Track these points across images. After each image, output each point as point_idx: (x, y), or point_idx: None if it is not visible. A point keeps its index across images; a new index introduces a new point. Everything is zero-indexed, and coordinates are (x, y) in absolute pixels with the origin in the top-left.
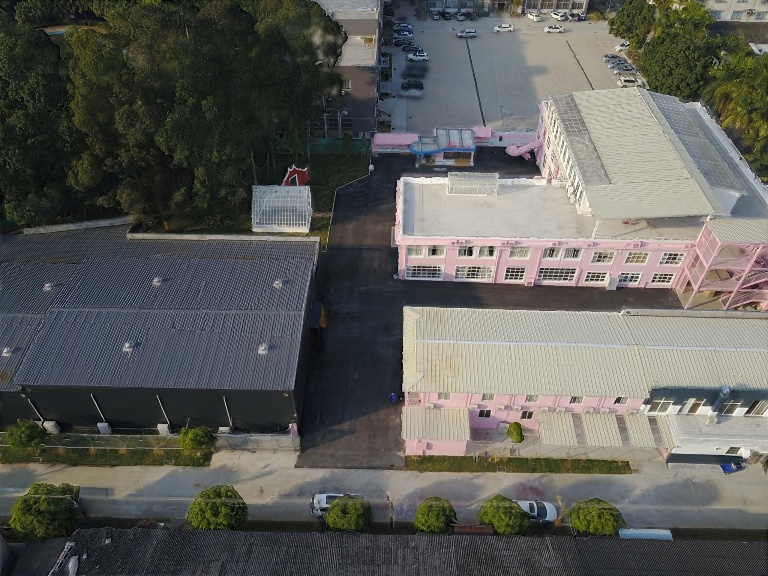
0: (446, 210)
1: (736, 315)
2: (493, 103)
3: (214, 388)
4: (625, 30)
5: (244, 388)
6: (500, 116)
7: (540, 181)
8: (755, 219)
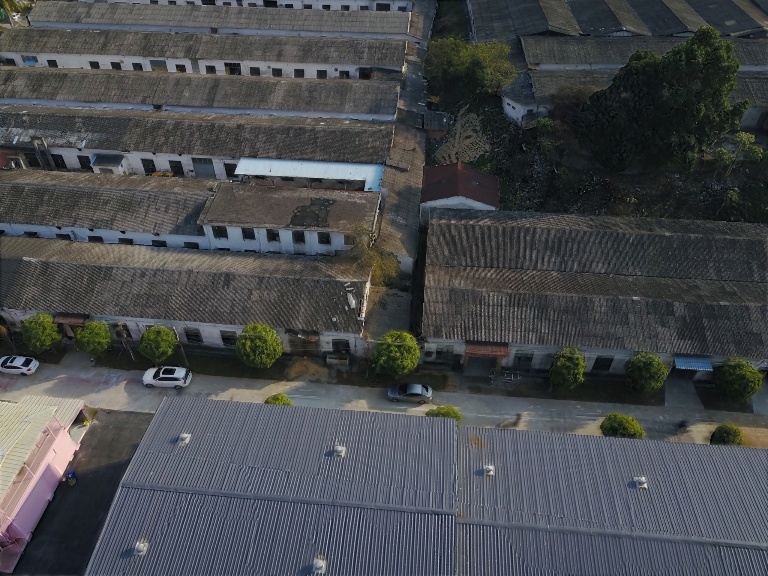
0: None
1: None
2: None
3: (244, 402)
4: None
5: (214, 400)
6: None
7: None
8: None
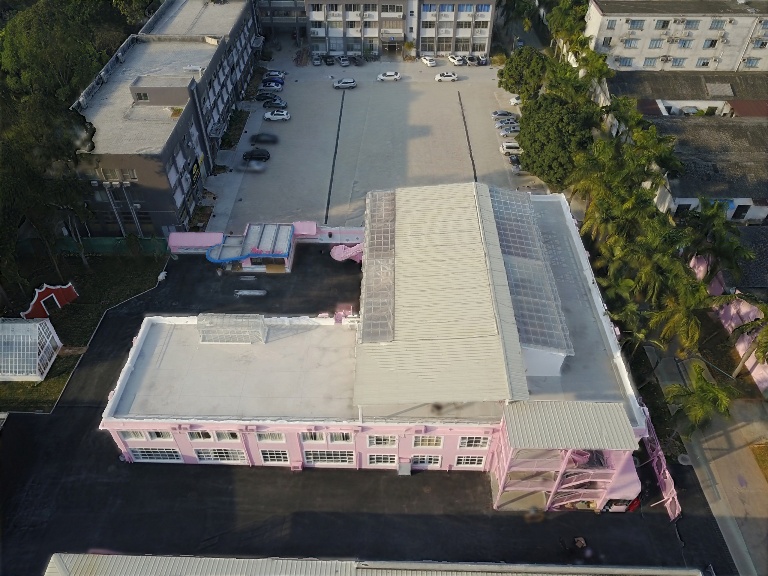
0: (188, 369)
1: (516, 569)
2: (347, 177)
3: None
4: (513, 84)
5: None
6: (350, 196)
7: (326, 320)
8: (572, 401)
